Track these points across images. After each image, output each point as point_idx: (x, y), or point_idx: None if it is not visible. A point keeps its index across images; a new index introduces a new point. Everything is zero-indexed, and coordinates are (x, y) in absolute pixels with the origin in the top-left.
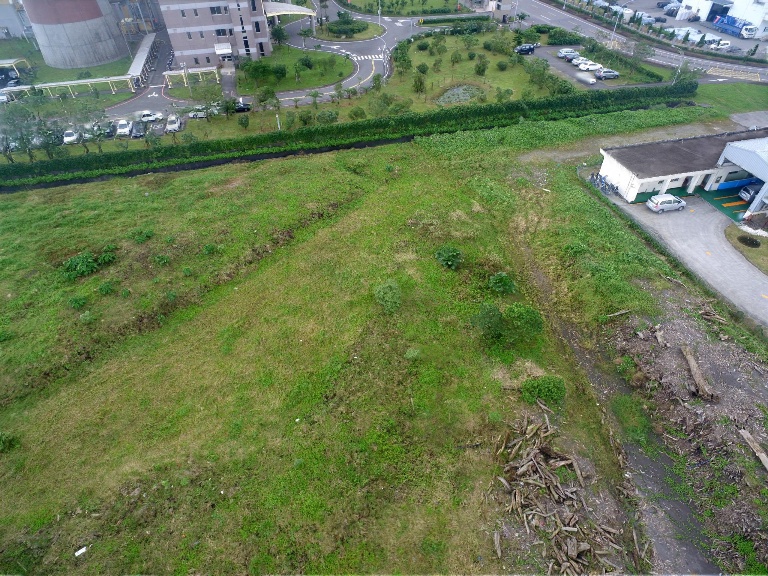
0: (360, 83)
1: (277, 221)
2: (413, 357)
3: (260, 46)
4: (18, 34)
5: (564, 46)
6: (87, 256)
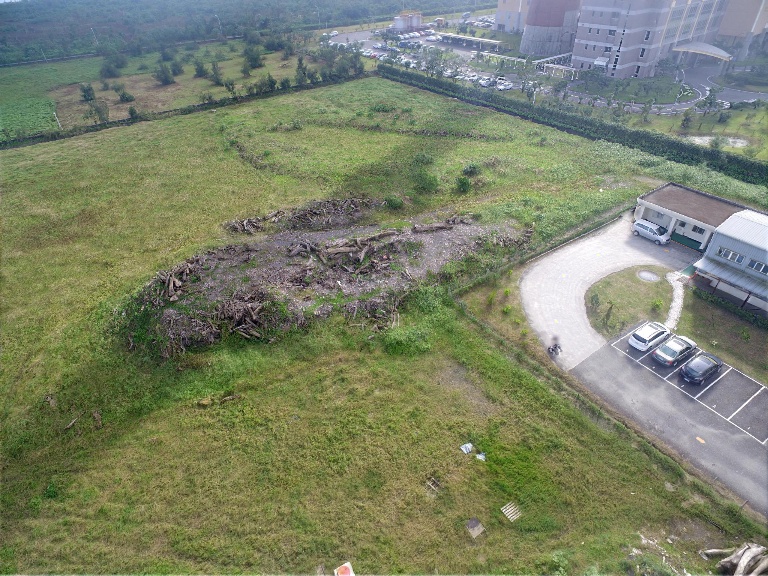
0: None
1: (450, 128)
2: (385, 169)
3: (638, 68)
4: (519, 29)
5: None
6: (383, 105)
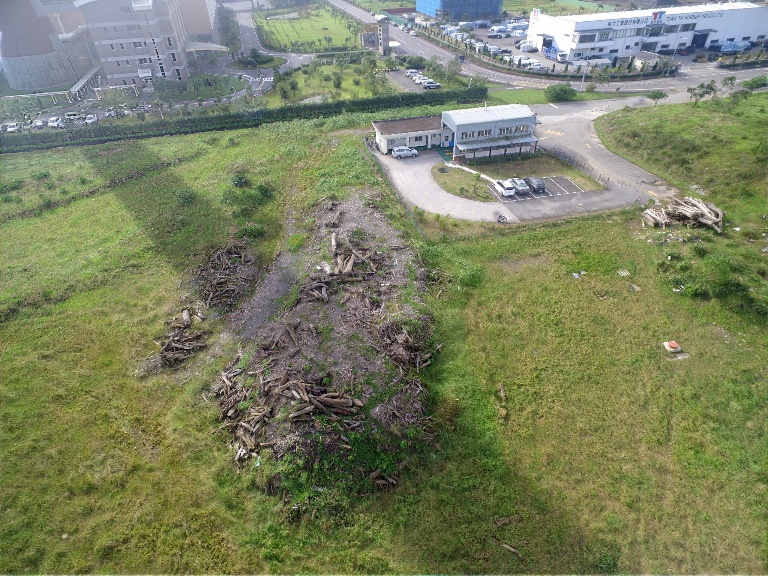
0: (243, 94)
1: (136, 167)
2: (180, 219)
3: (177, 72)
4: None
5: (418, 69)
6: None
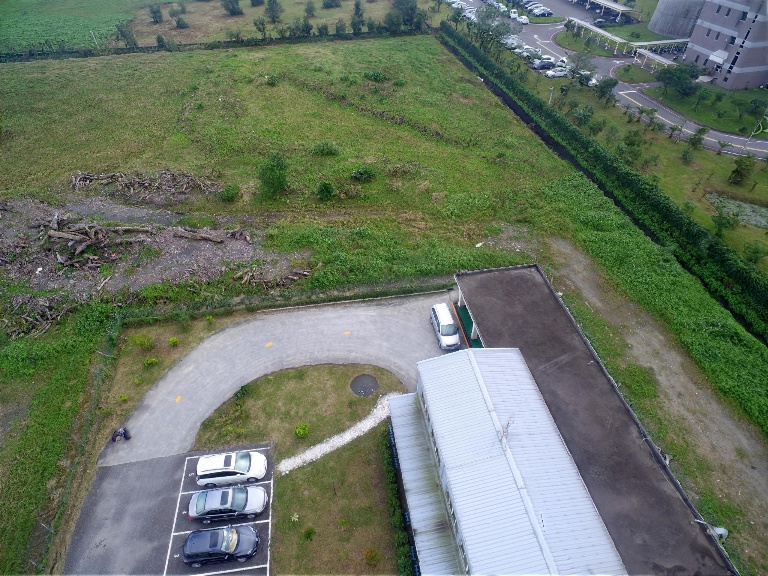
0: None
1: (413, 115)
2: None
3: None
4: None
5: None
6: (379, 73)
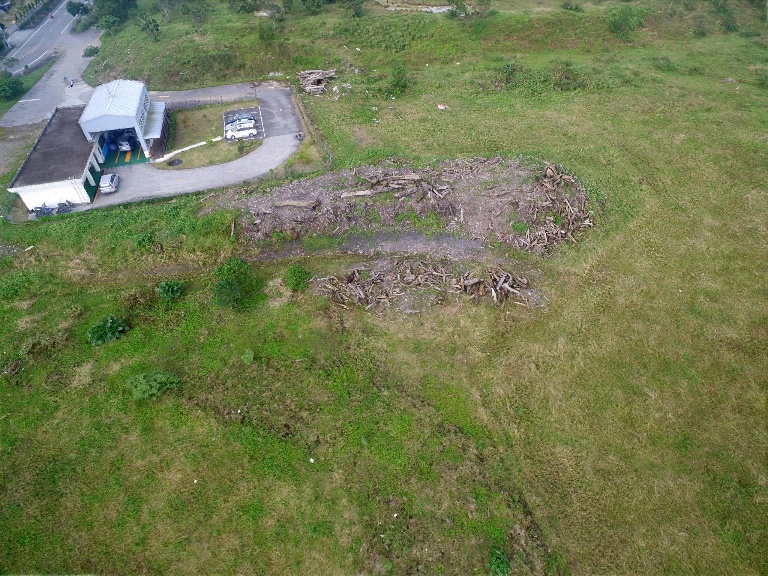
0: None
1: None
2: None
3: None
4: None
5: None
6: None
